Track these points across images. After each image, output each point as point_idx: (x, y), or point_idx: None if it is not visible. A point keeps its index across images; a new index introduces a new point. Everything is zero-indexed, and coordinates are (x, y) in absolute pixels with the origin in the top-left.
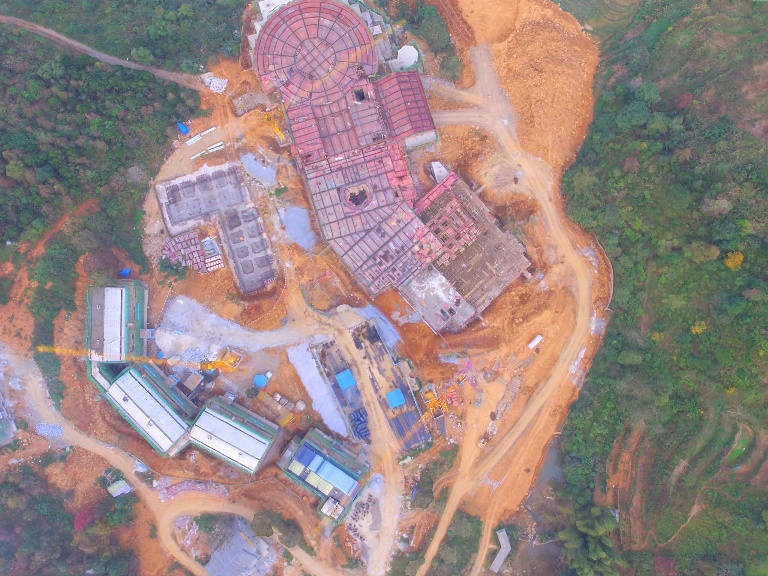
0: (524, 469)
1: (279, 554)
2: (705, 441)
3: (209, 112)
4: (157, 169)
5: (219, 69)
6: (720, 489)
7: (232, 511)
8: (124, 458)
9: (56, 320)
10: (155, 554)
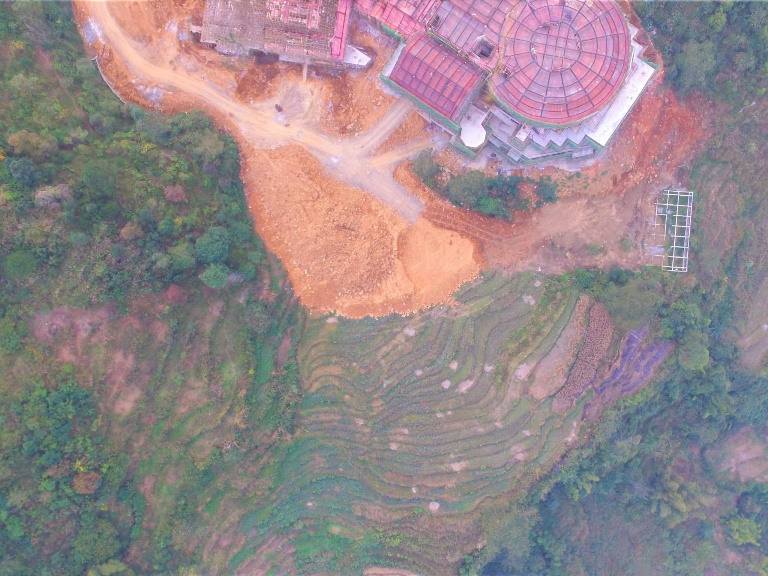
0: None
1: None
2: None
3: None
4: None
5: None
6: None
7: None
8: None
9: None
10: None
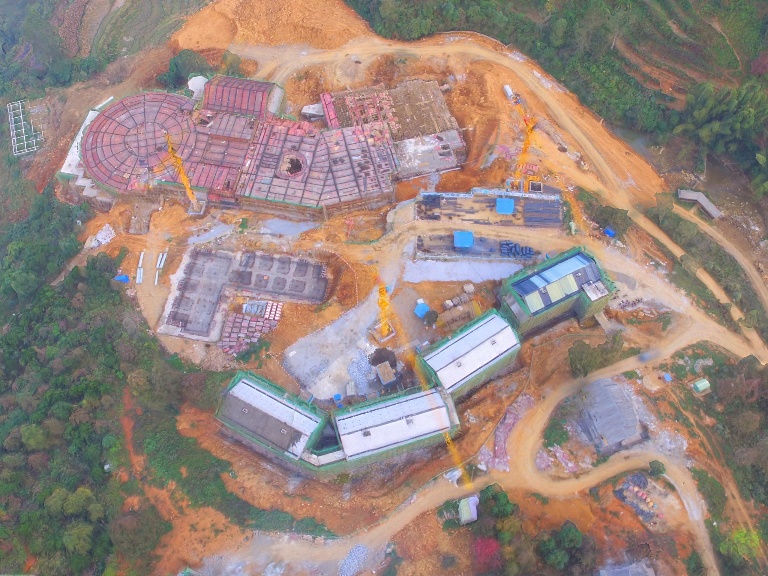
0: (625, 154)
1: (625, 381)
2: (657, 5)
3: (124, 250)
4: (142, 321)
5: (92, 227)
6: (704, 1)
7: (554, 405)
8: (434, 490)
9: (228, 488)
10: (570, 510)
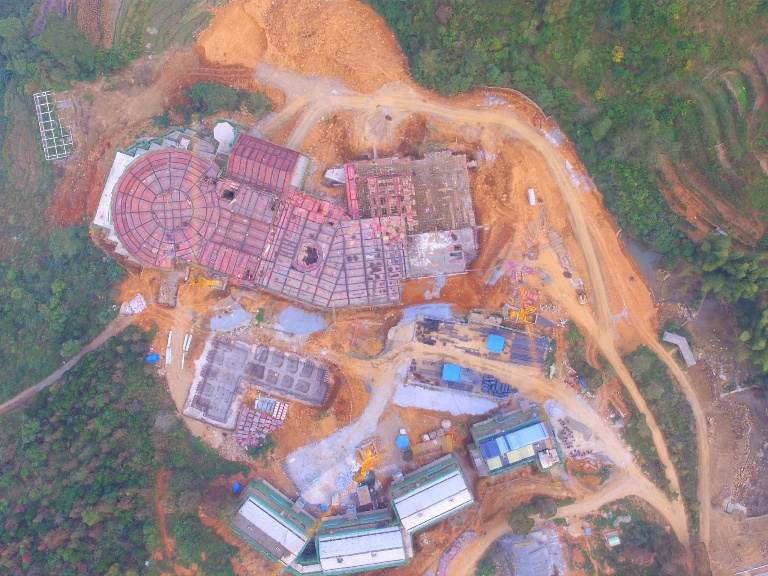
0: (628, 281)
1: (554, 528)
2: (714, 116)
3: (155, 327)
4: (171, 403)
5: (125, 294)
6: (762, 132)
7: (492, 541)
8: None
9: (236, 571)
10: None
